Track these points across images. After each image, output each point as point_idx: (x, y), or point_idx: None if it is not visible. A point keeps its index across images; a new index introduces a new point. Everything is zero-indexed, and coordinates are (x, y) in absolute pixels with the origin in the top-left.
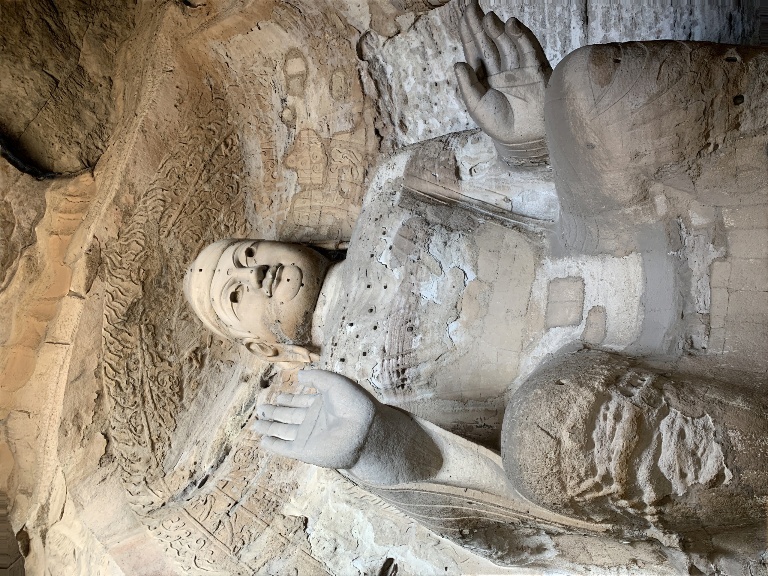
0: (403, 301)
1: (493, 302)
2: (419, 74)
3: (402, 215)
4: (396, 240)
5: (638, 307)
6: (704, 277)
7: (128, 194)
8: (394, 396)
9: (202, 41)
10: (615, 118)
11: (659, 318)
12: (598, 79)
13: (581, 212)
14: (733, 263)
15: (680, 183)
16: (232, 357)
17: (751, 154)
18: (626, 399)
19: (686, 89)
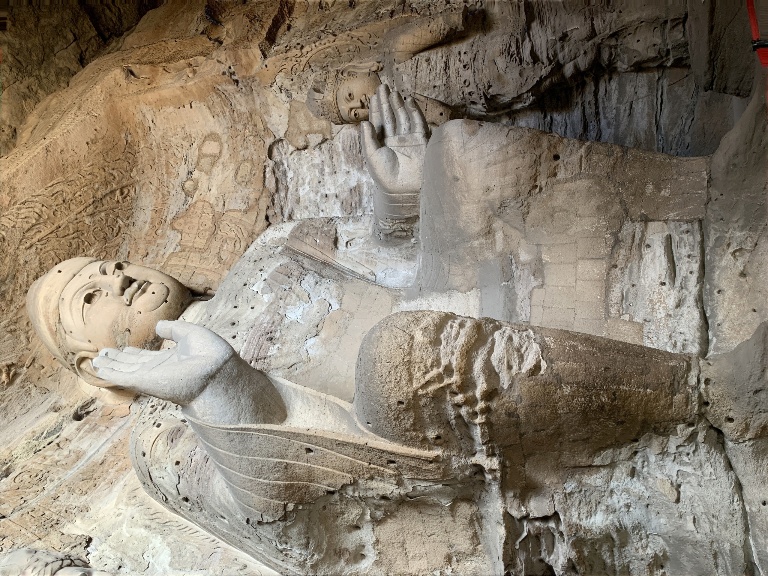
0: (268, 318)
1: (352, 325)
2: (314, 184)
3: (281, 259)
4: (272, 274)
5: None
6: (526, 299)
7: (6, 195)
8: None
9: (135, 103)
10: (476, 157)
11: None
12: (467, 131)
13: (439, 247)
14: (547, 289)
15: (515, 220)
16: (49, 385)
17: (563, 197)
18: None
19: (524, 145)
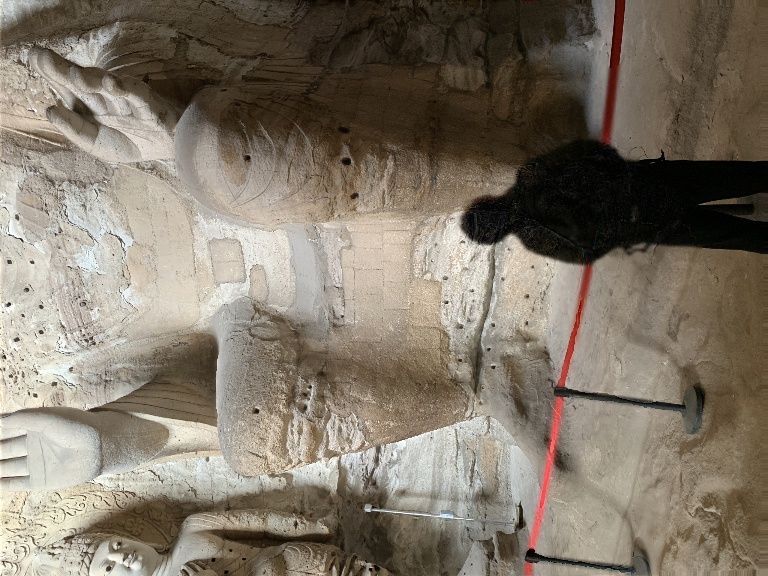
0: (62, 277)
1: (160, 266)
2: None
3: (13, 175)
4: (20, 209)
5: (290, 269)
6: (336, 259)
7: None
8: (88, 351)
9: None
10: (255, 207)
11: (307, 284)
12: (233, 179)
13: None
14: (356, 251)
15: None
16: None
17: (365, 218)
18: (303, 416)
19: (313, 190)
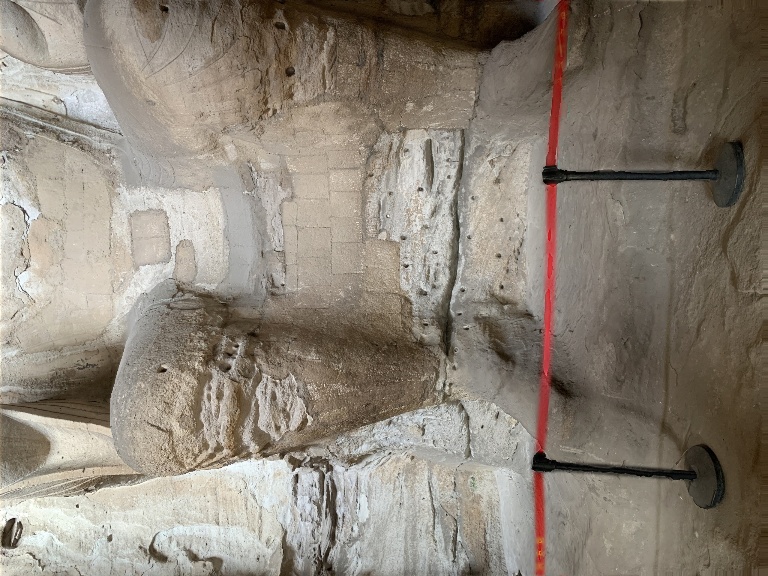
0: None
1: (68, 244)
2: None
3: None
4: None
5: (223, 241)
6: (276, 216)
7: None
8: None
9: None
10: (173, 79)
11: (243, 254)
12: (146, 31)
13: (151, 153)
14: (298, 203)
15: (246, 137)
16: None
17: (305, 120)
18: (225, 375)
19: (241, 55)
